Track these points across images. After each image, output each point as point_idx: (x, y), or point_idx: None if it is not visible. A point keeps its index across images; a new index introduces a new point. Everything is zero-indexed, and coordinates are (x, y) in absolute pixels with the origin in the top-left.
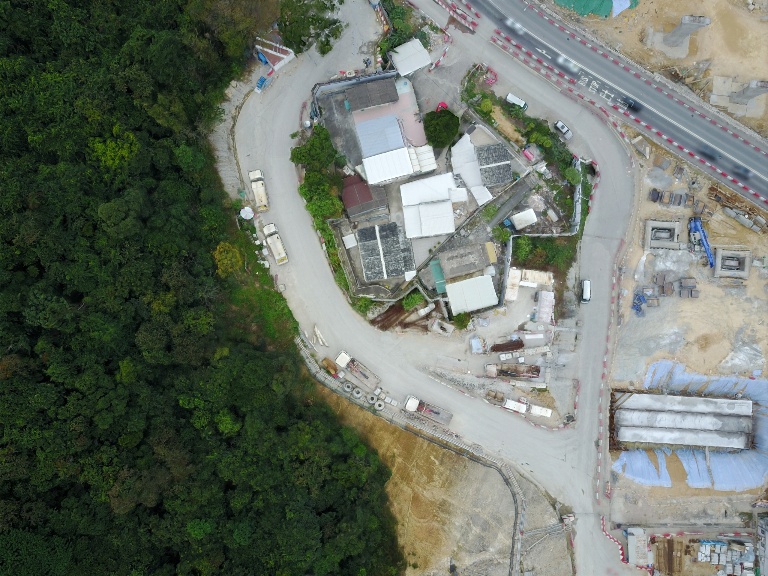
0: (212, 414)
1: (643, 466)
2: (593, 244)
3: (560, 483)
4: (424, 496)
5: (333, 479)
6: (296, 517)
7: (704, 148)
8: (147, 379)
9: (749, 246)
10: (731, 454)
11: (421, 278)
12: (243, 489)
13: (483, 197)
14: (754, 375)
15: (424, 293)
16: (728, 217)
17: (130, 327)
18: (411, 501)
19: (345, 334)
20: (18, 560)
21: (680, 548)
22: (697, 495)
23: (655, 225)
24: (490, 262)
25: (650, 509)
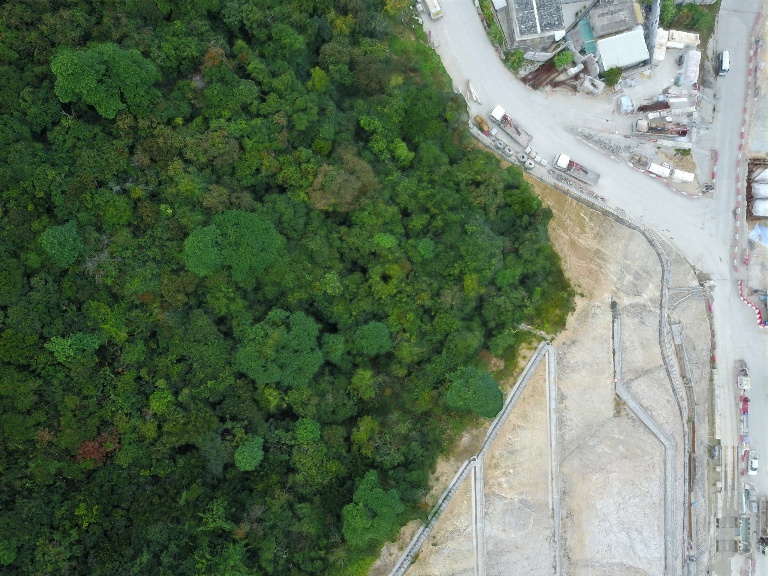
0: (387, 142)
1: None
2: (730, 18)
3: (698, 251)
4: (580, 243)
5: (506, 205)
6: (478, 231)
7: None
8: (331, 96)
9: None
10: None
11: (569, 40)
12: (420, 213)
13: None
14: None
15: (575, 49)
16: None
17: (311, 48)
18: (569, 245)
19: (497, 92)
20: (238, 231)
21: None
22: None
23: None
24: (638, 22)
25: None
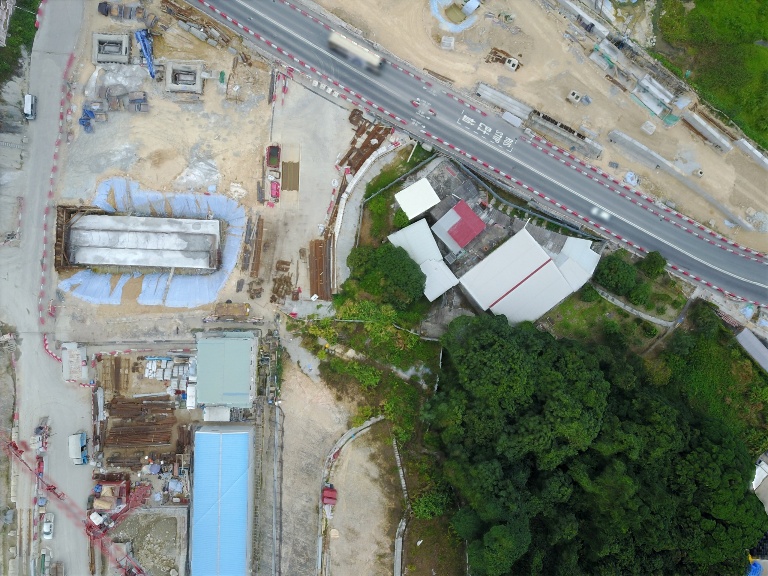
0: None
1: (100, 287)
2: (43, 60)
3: (3, 303)
4: None
5: None
6: None
7: None
8: None
9: (207, 61)
10: (200, 275)
11: None
12: None
13: None
14: (209, 190)
15: None
16: (184, 31)
17: None
18: None
19: None
20: None
21: (128, 365)
22: (148, 312)
23: (102, 38)
24: None
25: (98, 327)
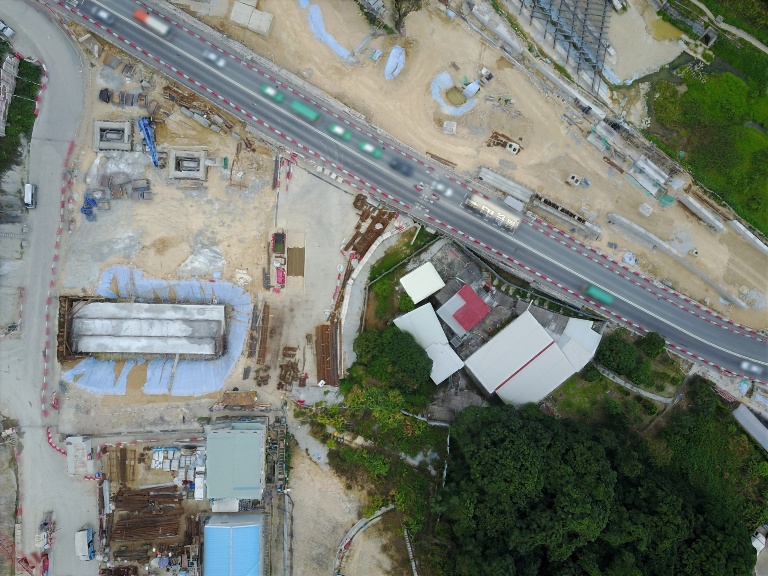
0: None
1: (103, 376)
2: (43, 147)
3: (4, 396)
4: None
5: None
6: None
7: (161, 47)
8: None
9: (211, 147)
10: (205, 361)
11: None
12: None
13: None
14: (214, 277)
15: None
16: (187, 117)
17: None
18: None
19: None
20: None
21: (133, 457)
22: (153, 402)
23: (104, 126)
24: None
25: (103, 418)
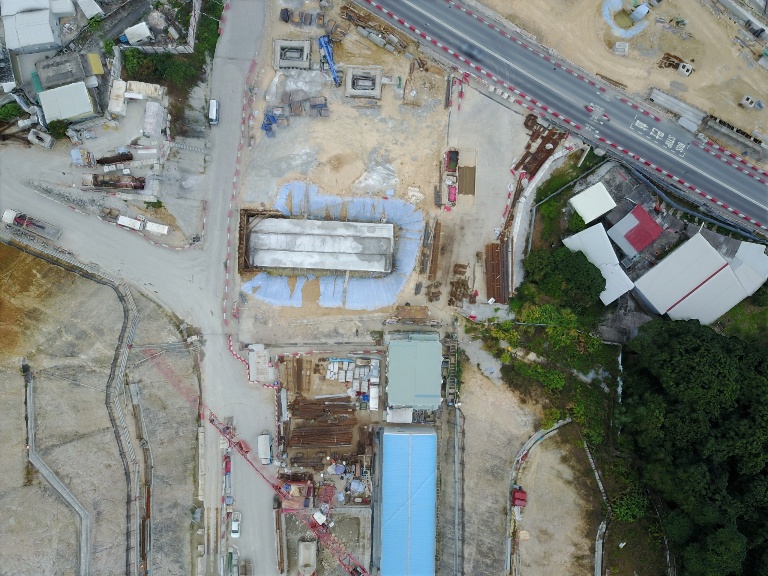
0: None
1: (279, 289)
2: (225, 66)
3: (188, 304)
4: (10, 303)
5: None
6: None
7: None
8: None
9: (384, 66)
10: (374, 278)
11: (24, 91)
12: None
13: (91, 9)
14: (387, 194)
15: (18, 102)
16: (362, 37)
17: None
18: None
19: None
20: None
21: (309, 367)
22: (328, 314)
23: (284, 44)
24: (93, 73)
25: (280, 329)
